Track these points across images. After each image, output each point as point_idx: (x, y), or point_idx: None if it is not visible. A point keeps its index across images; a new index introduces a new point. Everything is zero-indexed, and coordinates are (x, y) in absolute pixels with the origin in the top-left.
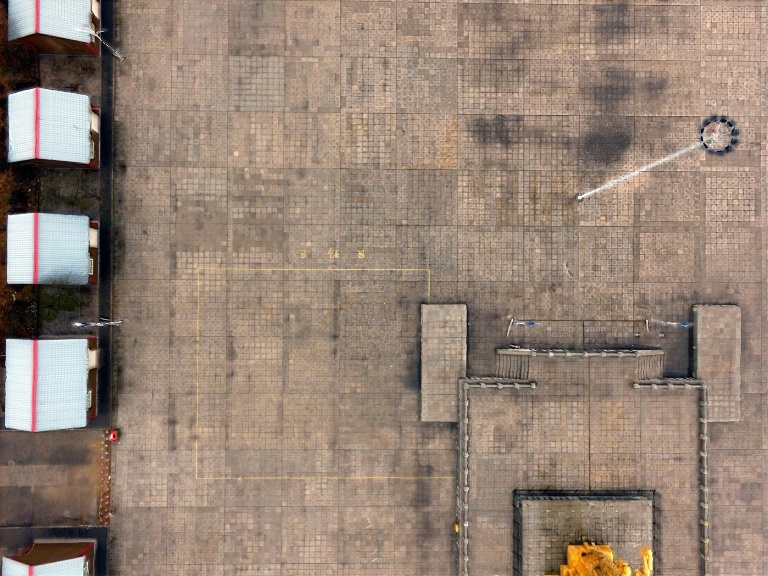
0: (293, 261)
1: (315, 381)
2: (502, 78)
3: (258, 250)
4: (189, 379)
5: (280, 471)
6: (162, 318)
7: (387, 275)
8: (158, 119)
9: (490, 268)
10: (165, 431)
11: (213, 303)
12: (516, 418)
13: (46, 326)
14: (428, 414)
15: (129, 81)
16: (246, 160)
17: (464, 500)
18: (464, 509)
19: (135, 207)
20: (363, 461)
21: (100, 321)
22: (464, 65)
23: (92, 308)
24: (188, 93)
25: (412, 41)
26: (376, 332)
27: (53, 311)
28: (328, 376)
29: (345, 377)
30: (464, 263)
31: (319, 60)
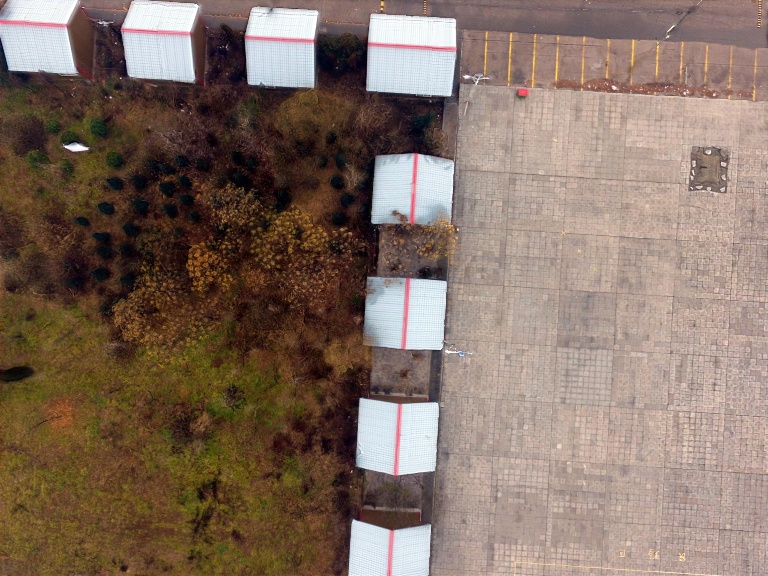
0: (612, 560)
1: None
2: None
3: (577, 546)
4: None
5: None
6: None
7: None
8: (483, 407)
9: None
10: None
11: None
12: None
13: None
14: None
15: (456, 368)
16: (569, 453)
17: None
18: None
19: (456, 495)
20: None
21: None
22: None
23: None
24: (514, 382)
25: (745, 341)
26: None
27: None
28: None
29: None
30: None
31: (648, 355)
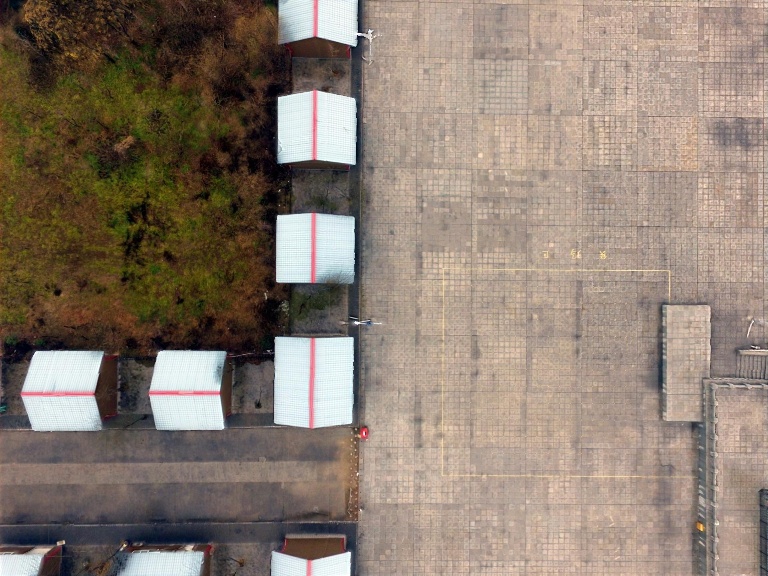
0: (536, 261)
1: (558, 380)
2: (742, 81)
3: (502, 250)
4: (435, 377)
5: (524, 469)
6: (408, 317)
7: (628, 276)
8: (405, 121)
9: (730, 269)
10: (411, 429)
11: (458, 303)
12: (762, 418)
13: (297, 324)
14: (673, 414)
15: (377, 84)
16: (490, 162)
17: (713, 499)
18: (713, 508)
19: (382, 208)
20: (605, 460)
21: (349, 320)
22: (704, 68)
23: (342, 307)
24: (434, 96)
25: (653, 45)
26: (618, 332)
27: (304, 310)
28: (571, 375)
29: (587, 376)
30: (704, 264)
31: (562, 63)
